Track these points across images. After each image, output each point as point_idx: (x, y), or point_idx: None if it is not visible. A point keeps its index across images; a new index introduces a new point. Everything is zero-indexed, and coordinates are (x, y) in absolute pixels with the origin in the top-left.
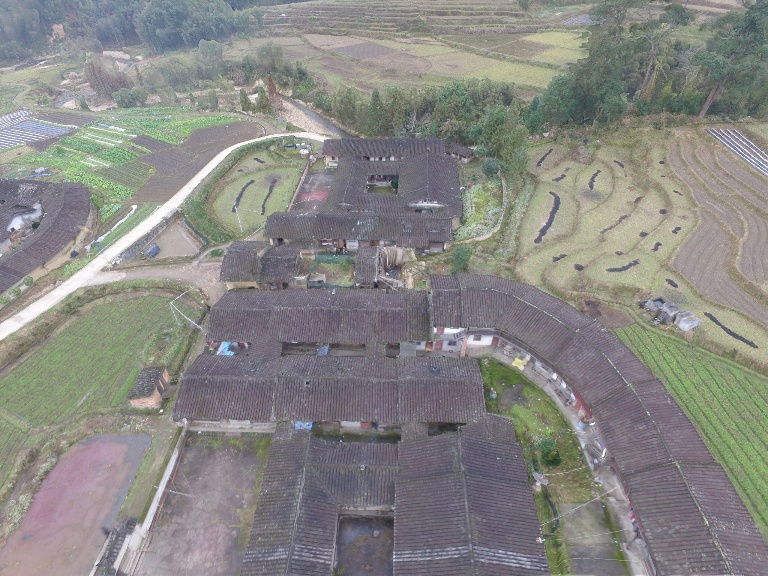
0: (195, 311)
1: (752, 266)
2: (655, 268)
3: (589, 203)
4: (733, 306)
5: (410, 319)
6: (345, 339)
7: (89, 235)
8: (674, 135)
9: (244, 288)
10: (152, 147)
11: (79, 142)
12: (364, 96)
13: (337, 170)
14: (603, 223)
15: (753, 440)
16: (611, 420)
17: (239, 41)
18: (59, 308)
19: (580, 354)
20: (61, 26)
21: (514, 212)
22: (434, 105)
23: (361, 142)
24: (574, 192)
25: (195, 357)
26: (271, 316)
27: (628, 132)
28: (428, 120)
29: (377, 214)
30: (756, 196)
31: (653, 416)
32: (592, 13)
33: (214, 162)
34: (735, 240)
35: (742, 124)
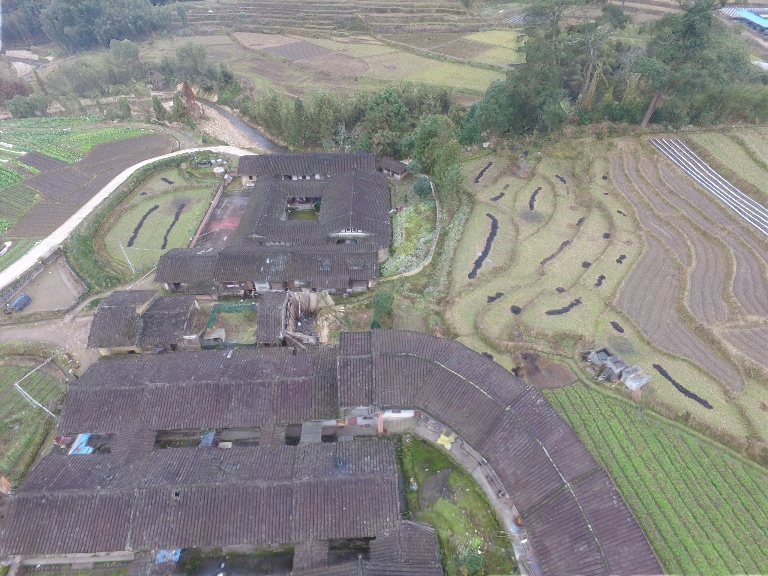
0: (60, 384)
1: (702, 303)
2: (599, 308)
3: (529, 227)
4: (684, 354)
5: (315, 392)
6: (235, 422)
7: None
8: (617, 146)
9: (120, 354)
10: (43, 166)
11: None
12: (291, 103)
13: (252, 193)
14: (543, 251)
15: (712, 536)
16: (546, 537)
17: (161, 40)
18: None
19: (511, 440)
20: None
21: (448, 239)
22: None
23: (282, 159)
24: (513, 214)
25: (49, 452)
26: (144, 396)
27: (570, 143)
28: (359, 131)
29: (291, 249)
30: (702, 217)
31: (596, 530)
32: (527, 15)
33: (113, 184)
34: (683, 270)
35: (685, 133)
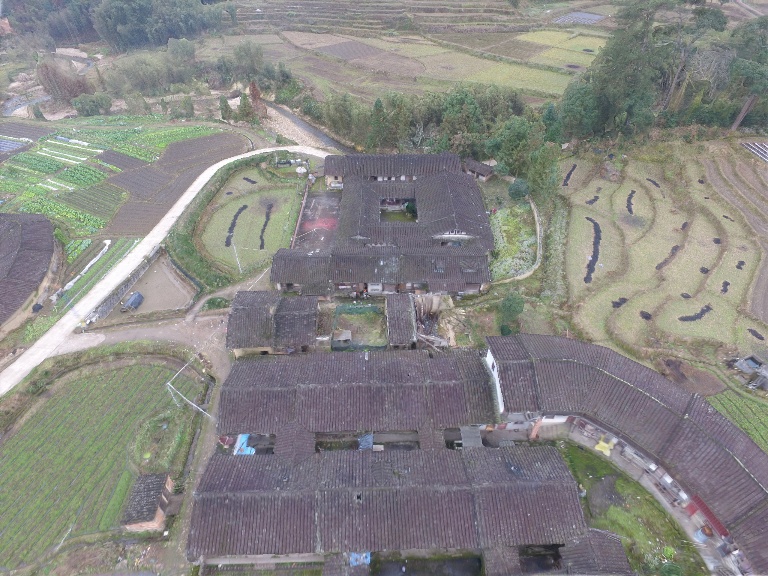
0: (196, 384)
1: None
2: (732, 315)
3: (633, 231)
4: None
5: (469, 396)
6: (392, 425)
7: (54, 281)
8: (708, 150)
9: (256, 354)
10: (123, 165)
11: (35, 160)
12: (360, 104)
13: (344, 194)
14: (655, 256)
15: None
16: (761, 548)
17: (211, 39)
18: (22, 389)
19: (697, 449)
20: (6, 20)
21: (552, 243)
22: (439, 114)
23: (367, 159)
24: (614, 218)
25: (203, 451)
26: (297, 397)
27: (657, 146)
28: (436, 132)
29: (401, 251)
30: None
31: None
32: (619, 16)
33: (198, 184)
34: None
35: None
